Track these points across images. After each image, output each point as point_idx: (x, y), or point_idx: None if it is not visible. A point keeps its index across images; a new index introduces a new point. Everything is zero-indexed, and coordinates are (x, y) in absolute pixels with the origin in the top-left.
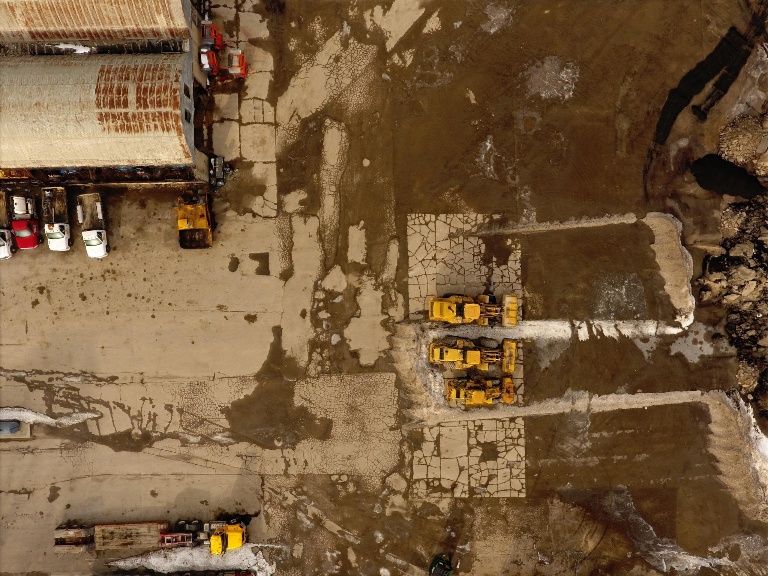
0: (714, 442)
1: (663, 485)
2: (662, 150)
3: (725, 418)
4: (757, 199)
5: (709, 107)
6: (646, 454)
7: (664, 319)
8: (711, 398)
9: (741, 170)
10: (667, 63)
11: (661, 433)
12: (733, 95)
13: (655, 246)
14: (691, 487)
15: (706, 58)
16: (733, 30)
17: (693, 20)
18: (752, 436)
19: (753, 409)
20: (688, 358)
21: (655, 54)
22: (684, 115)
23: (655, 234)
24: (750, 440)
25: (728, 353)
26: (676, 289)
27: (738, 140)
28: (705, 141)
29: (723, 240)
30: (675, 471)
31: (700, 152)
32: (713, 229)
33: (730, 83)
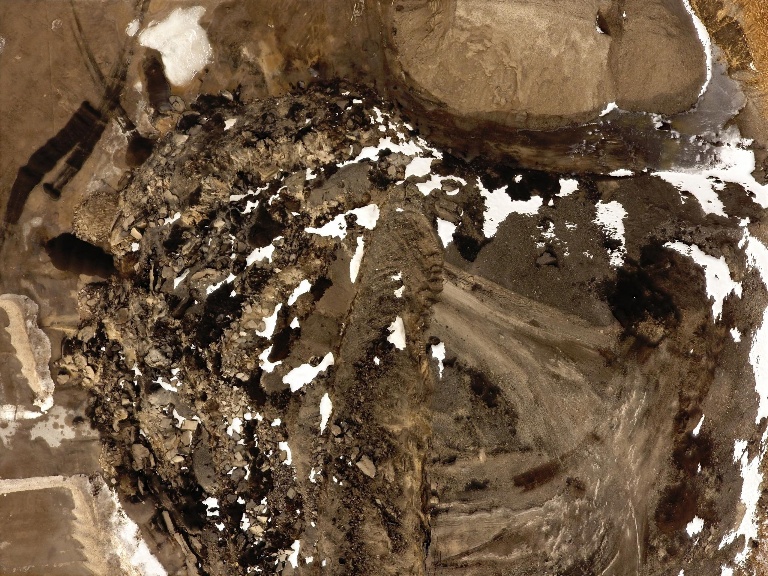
0: (77, 528)
1: (26, 573)
2: (14, 230)
3: (83, 504)
4: (112, 279)
5: (62, 185)
6: (7, 542)
7: (22, 403)
8: (71, 483)
9: (96, 249)
10: (16, 140)
11: (22, 520)
12: (87, 172)
13: (8, 329)
14: (56, 574)
15: (57, 134)
16: (83, 105)
17: (43, 95)
18: (113, 522)
19: (118, 493)
20: (49, 443)
21: (3, 131)
22: (36, 193)
23: (9, 316)
24: (109, 526)
25: (91, 437)
26: (29, 373)
27: (82, 220)
28: (60, 220)
29: (81, 321)
30: (39, 558)
31: (54, 231)
32: (70, 310)
33: (83, 159)
